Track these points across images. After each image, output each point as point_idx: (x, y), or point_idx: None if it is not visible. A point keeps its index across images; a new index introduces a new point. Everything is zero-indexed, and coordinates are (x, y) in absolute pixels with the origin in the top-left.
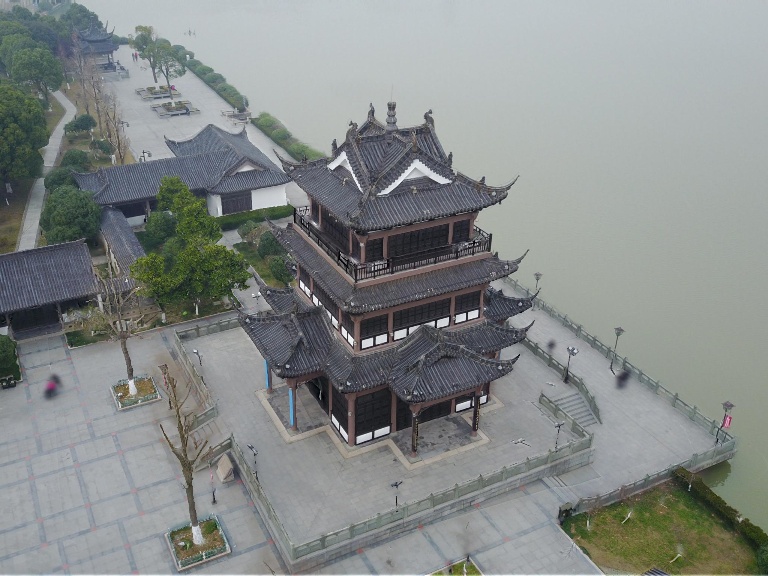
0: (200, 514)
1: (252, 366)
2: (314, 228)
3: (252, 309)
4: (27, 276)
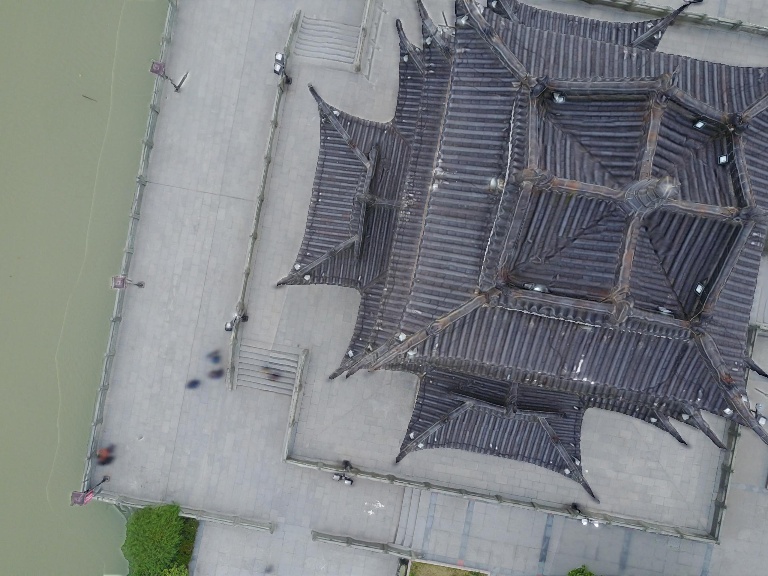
0: None
1: None
2: None
3: (543, 575)
4: None
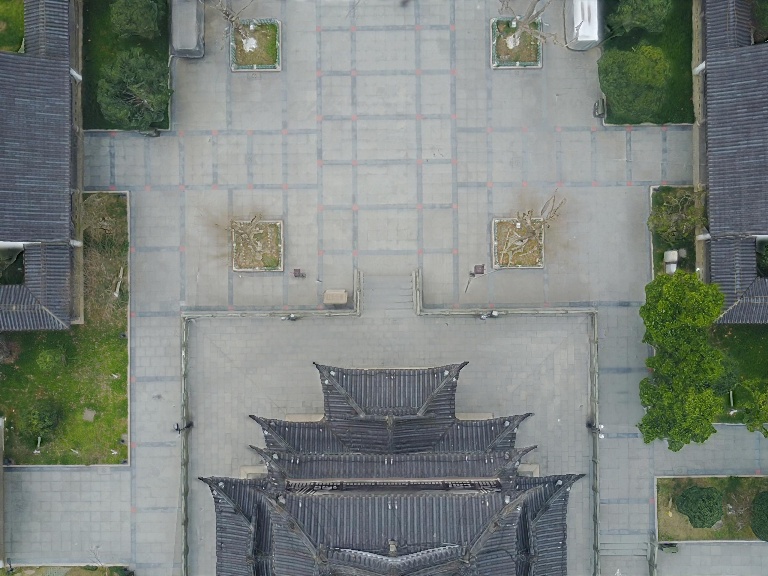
0: (295, 258)
1: (496, 382)
2: (425, 486)
3: None
4: (767, 141)
